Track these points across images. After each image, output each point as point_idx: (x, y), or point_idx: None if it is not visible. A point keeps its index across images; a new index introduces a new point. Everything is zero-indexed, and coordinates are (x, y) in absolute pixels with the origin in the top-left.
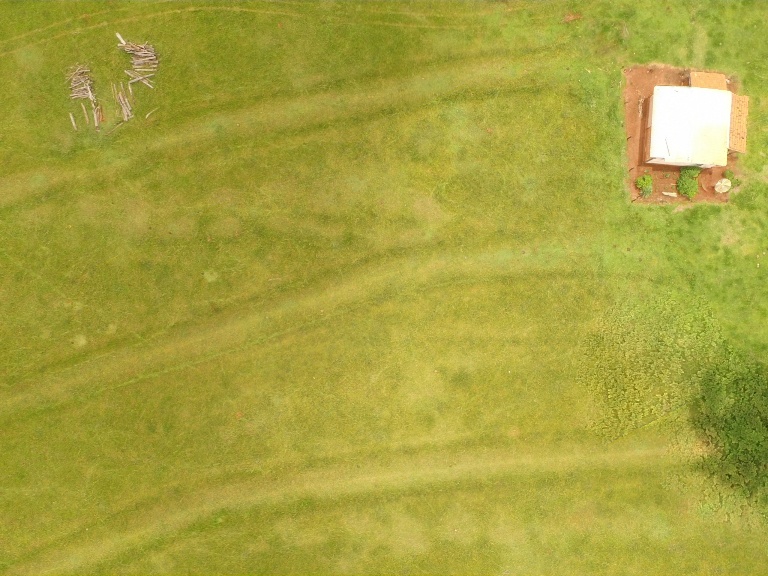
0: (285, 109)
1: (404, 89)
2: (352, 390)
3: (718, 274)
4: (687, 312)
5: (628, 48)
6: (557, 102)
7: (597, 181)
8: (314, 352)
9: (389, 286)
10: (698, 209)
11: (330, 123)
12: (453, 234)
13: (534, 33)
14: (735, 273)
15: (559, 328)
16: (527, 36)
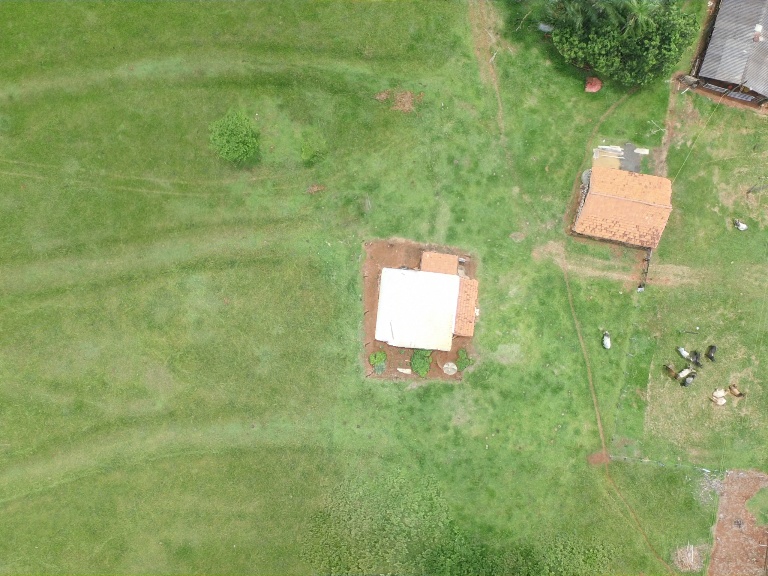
0: (22, 273)
1: (143, 256)
2: (75, 560)
3: (448, 454)
4: (415, 491)
5: (370, 221)
6: (296, 274)
7: (332, 355)
8: (38, 520)
9: (117, 455)
10: (431, 387)
11: (68, 288)
12: (184, 405)
13: (277, 203)
14: (465, 453)
15: (286, 503)
16: (270, 206)
